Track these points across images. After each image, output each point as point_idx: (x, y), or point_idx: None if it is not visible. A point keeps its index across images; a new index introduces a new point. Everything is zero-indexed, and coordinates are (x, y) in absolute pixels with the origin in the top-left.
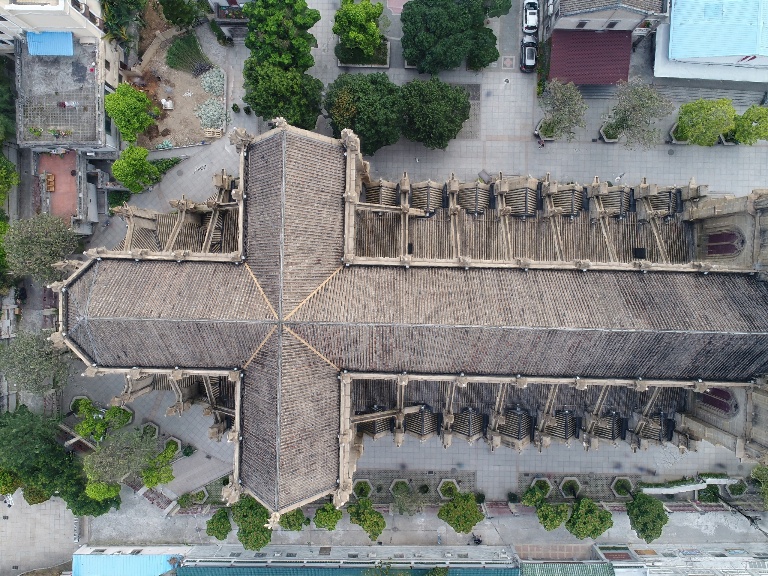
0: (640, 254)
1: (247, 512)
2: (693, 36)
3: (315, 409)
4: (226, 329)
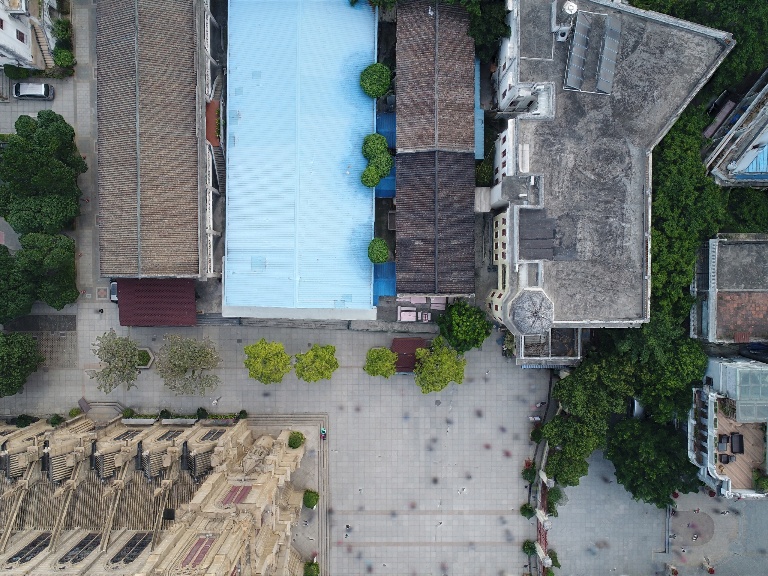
0: (168, 516)
1: None
2: (243, 285)
3: None
4: None
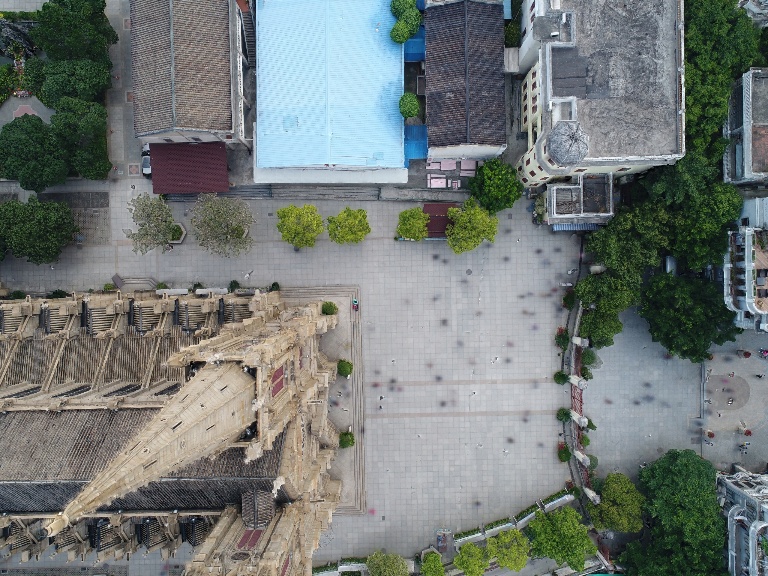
0: None
1: None
2: (275, 146)
3: None
4: None
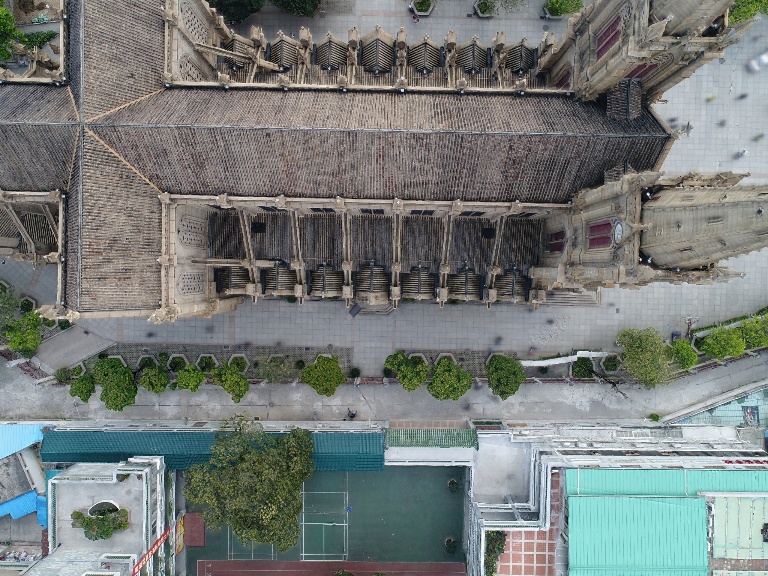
0: None
1: (108, 371)
2: None
3: (130, 224)
4: (32, 135)
